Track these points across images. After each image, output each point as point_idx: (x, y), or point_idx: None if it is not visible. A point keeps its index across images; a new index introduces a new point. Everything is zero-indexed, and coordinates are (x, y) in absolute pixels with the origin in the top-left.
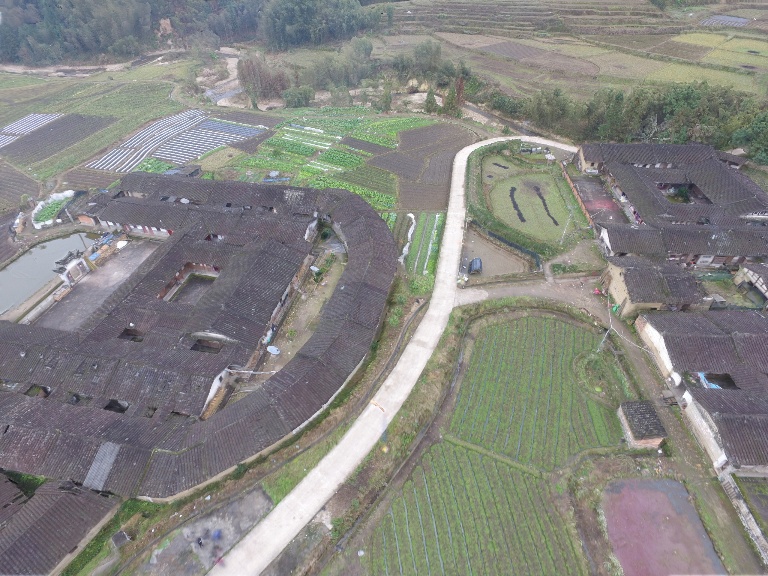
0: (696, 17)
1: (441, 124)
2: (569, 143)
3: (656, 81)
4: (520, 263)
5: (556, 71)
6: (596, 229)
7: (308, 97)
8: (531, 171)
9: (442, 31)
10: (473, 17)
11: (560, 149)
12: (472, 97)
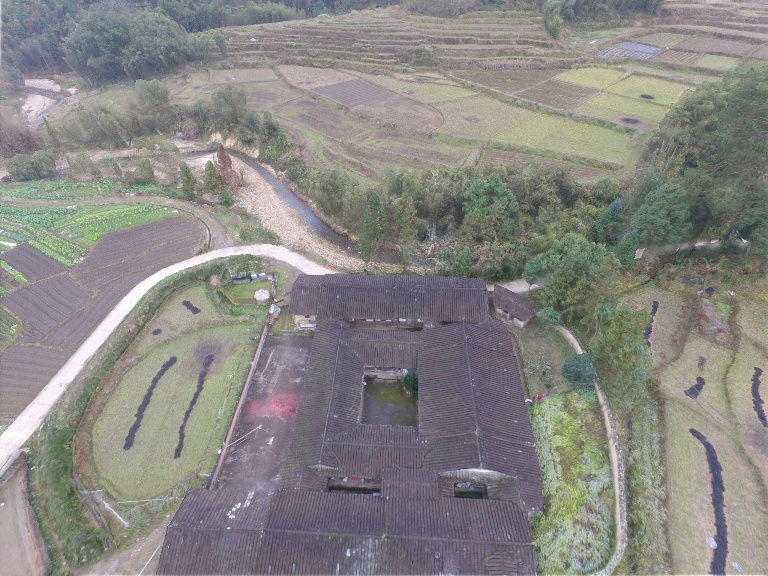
0: (597, 46)
1: (176, 218)
2: (318, 260)
3: (503, 144)
4: (36, 572)
5: (387, 126)
6: (205, 488)
7: (41, 167)
8: (223, 321)
9: (288, 63)
10: (327, 46)
11: (299, 272)
12: (274, 161)
